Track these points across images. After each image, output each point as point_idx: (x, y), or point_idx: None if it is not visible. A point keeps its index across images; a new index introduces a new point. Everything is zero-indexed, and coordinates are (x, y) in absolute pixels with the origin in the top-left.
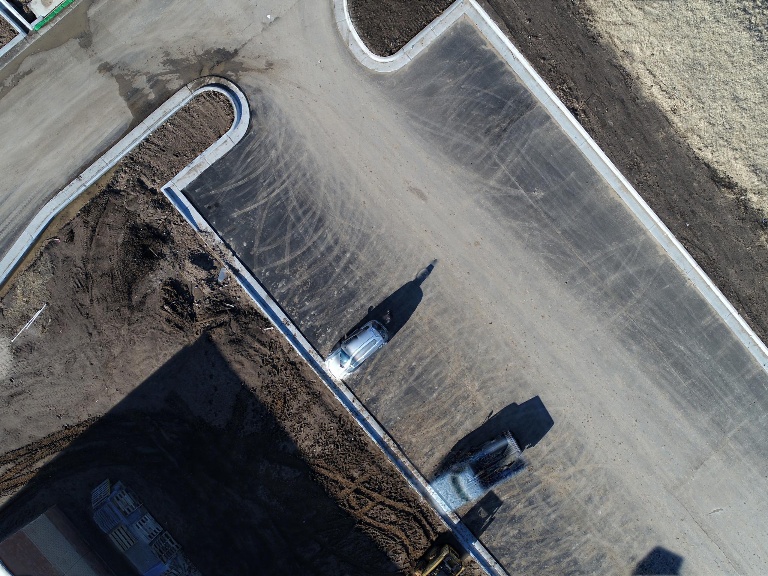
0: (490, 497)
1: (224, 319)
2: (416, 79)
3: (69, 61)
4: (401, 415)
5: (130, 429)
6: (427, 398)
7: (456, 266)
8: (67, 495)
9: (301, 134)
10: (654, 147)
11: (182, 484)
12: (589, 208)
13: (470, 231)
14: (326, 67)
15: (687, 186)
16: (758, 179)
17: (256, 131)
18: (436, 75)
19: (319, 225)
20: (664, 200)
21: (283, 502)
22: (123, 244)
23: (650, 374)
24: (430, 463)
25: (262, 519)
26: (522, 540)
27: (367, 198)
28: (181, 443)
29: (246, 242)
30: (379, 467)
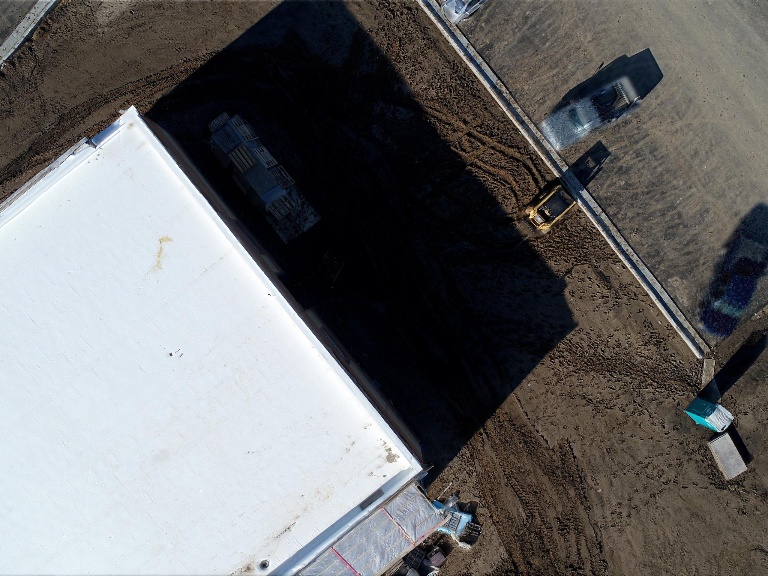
0: (598, 147)
1: None
2: None
3: None
4: (514, 63)
5: (248, 65)
6: (540, 47)
7: None
8: (184, 128)
9: None
10: None
11: (297, 121)
12: None
13: None
14: None
15: None
16: None
17: None
18: None
19: None
20: None
21: (396, 141)
22: None
23: (759, 29)
24: (541, 111)
25: (375, 158)
26: (628, 191)
27: None
28: (297, 80)
29: None
30: (490, 113)
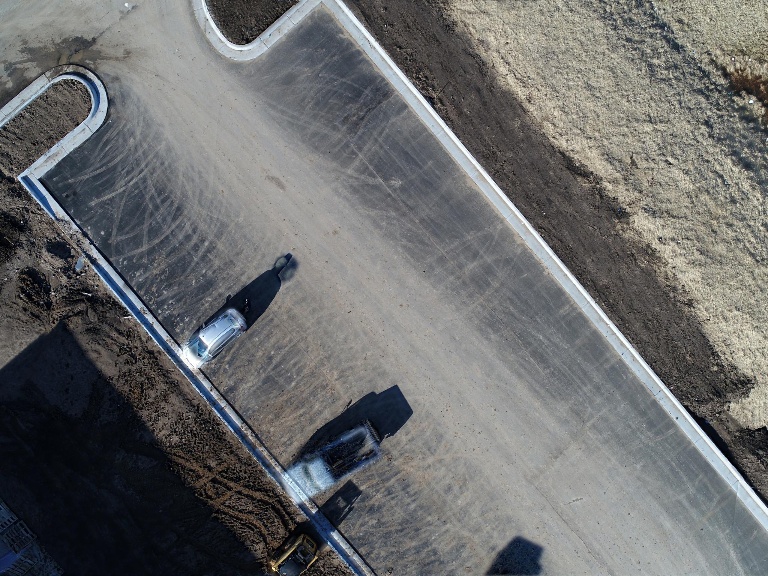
0: (349, 486)
1: (81, 308)
2: (274, 68)
3: None
4: (259, 404)
5: None
6: (285, 387)
7: (314, 255)
8: None
9: (159, 123)
10: (510, 136)
11: (38, 473)
12: (447, 197)
13: (328, 220)
14: (184, 55)
15: (543, 175)
16: (612, 168)
17: (114, 119)
18: (294, 64)
19: (177, 214)
20: (520, 189)
21: (139, 491)
22: None
23: (509, 363)
24: (288, 452)
25: (118, 508)
26: (381, 530)
27: (225, 187)
28: (37, 432)
29: (104, 231)
30: (237, 456)
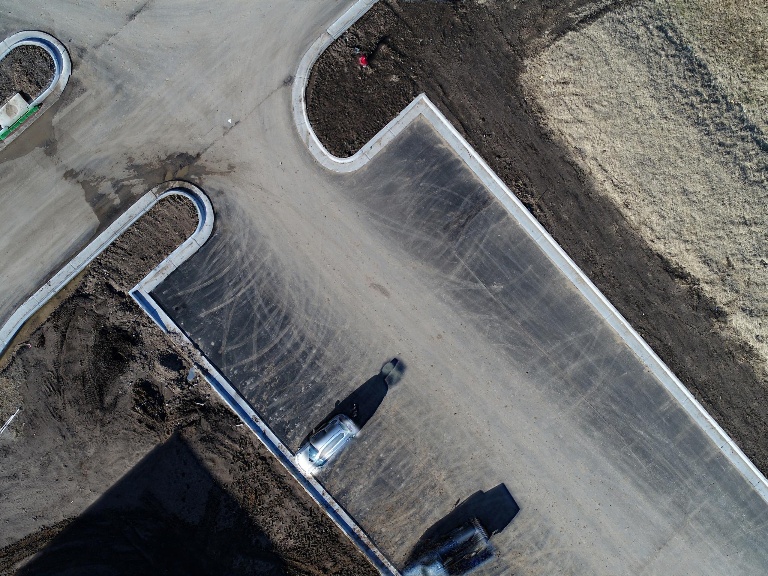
0: None
1: (194, 418)
2: (375, 178)
3: (35, 169)
4: (370, 506)
5: (105, 529)
6: (395, 489)
7: (420, 359)
8: None
9: (265, 234)
10: (608, 240)
11: None
12: (547, 299)
13: (432, 325)
14: (287, 169)
15: (641, 277)
16: (710, 269)
17: (221, 233)
18: (395, 174)
19: (285, 323)
20: (620, 291)
21: None
22: (93, 347)
23: (611, 459)
24: (400, 552)
25: None
26: None
27: (331, 295)
28: (155, 541)
29: (214, 342)
30: (350, 557)
